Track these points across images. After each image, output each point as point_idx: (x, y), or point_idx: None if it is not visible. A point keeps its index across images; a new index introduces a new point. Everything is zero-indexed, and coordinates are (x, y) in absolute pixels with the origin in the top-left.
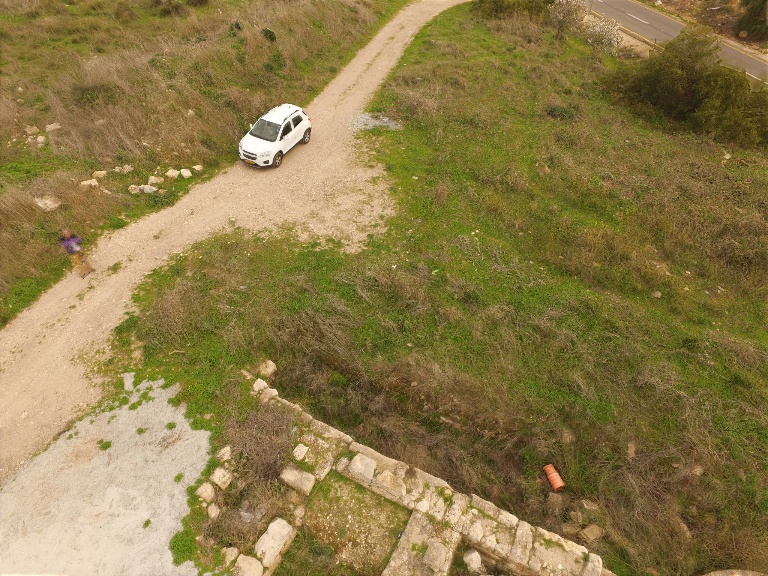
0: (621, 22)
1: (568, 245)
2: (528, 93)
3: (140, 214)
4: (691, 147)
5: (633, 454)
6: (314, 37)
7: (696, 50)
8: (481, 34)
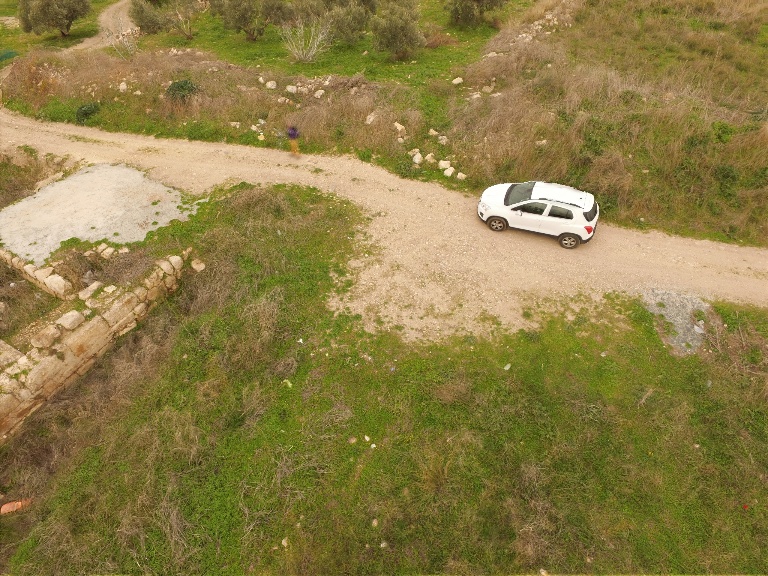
0: None
1: None
2: None
3: (382, 164)
4: None
5: None
6: None
7: None
8: None
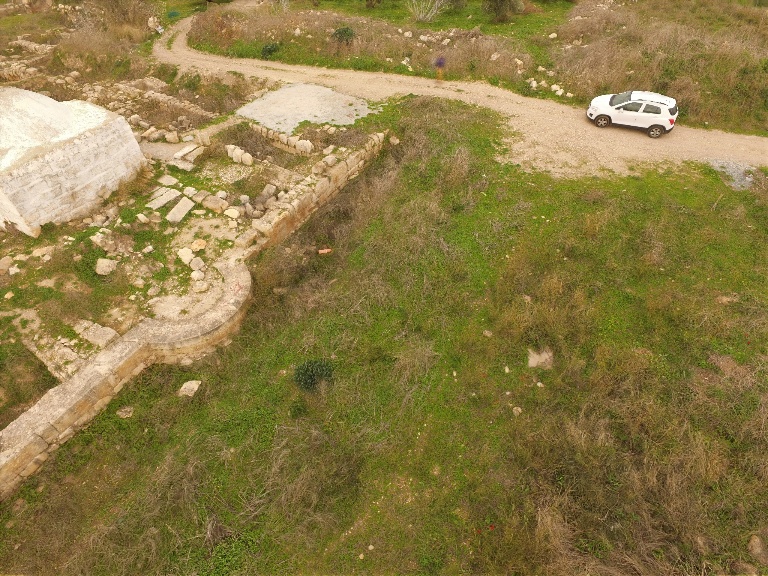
0: None
1: None
2: None
3: (508, 87)
4: None
5: None
6: None
7: None
8: None
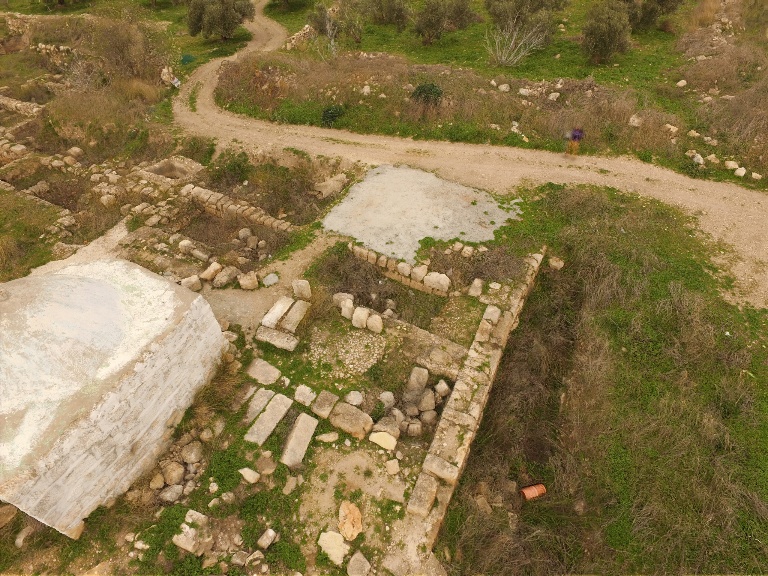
0: None
1: None
2: None
3: (666, 165)
4: None
5: None
6: None
7: None
8: None
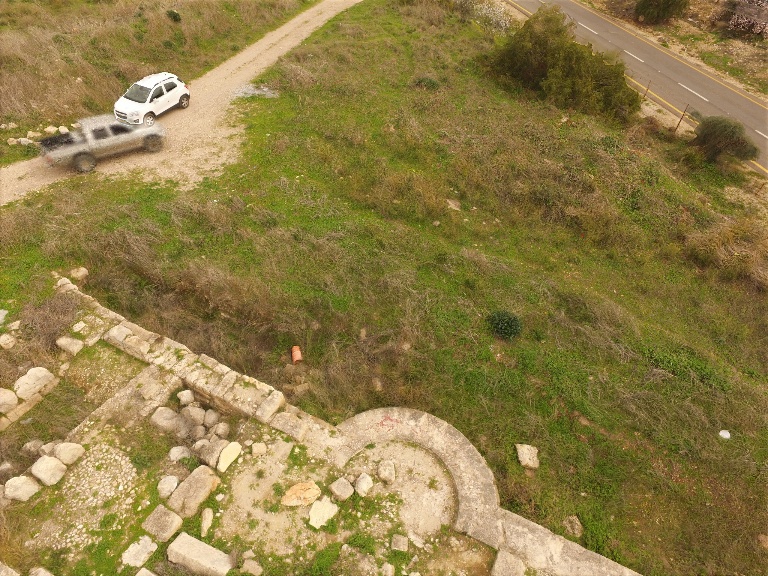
0: (530, 8)
1: (378, 187)
2: (406, 68)
3: (12, 161)
4: (535, 112)
5: (364, 337)
6: (223, 19)
7: (551, 27)
8: (391, 18)
